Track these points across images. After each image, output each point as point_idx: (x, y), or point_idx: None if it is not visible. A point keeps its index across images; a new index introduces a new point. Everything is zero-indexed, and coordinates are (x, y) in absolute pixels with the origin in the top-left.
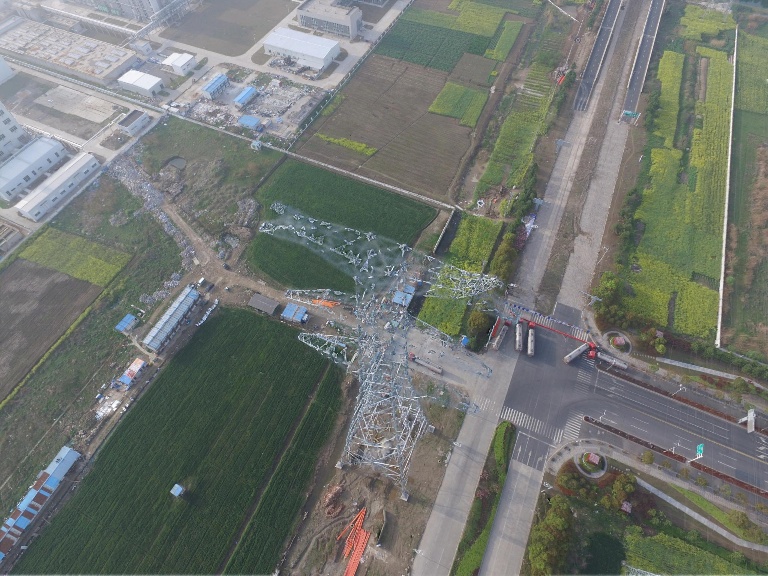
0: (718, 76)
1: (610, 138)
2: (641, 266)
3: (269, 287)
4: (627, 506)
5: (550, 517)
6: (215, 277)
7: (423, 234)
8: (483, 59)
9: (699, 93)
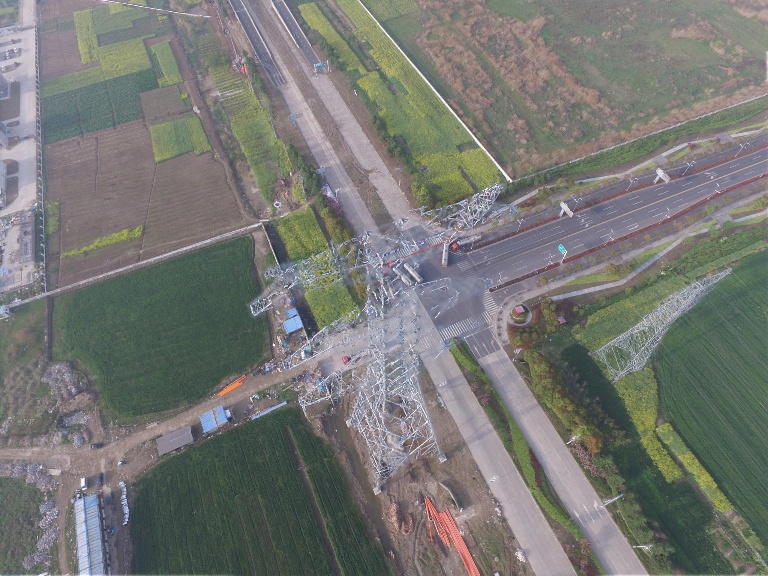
0: (349, 6)
1: (322, 92)
2: (426, 166)
3: (164, 422)
4: (561, 319)
5: (536, 369)
6: (95, 466)
7: (257, 263)
8: (162, 90)
9: (348, 25)
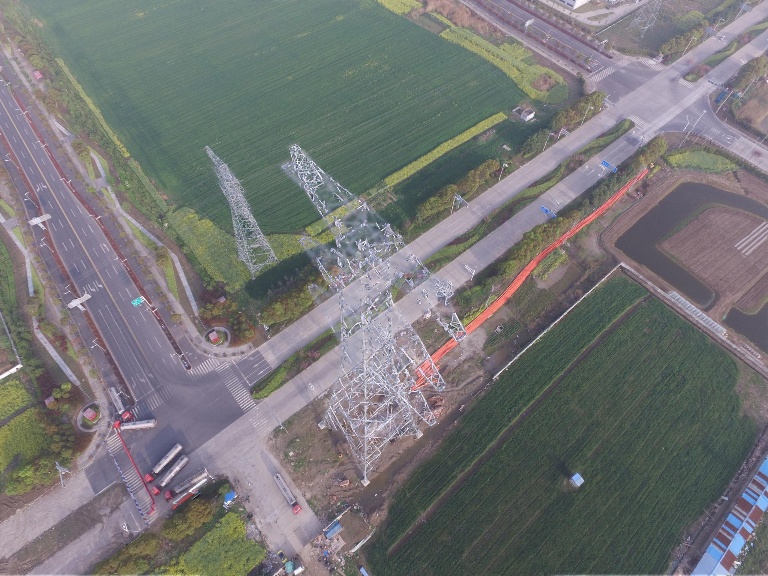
0: None
1: None
2: None
3: None
4: (221, 300)
5: (280, 313)
6: None
7: None
8: None
9: None
